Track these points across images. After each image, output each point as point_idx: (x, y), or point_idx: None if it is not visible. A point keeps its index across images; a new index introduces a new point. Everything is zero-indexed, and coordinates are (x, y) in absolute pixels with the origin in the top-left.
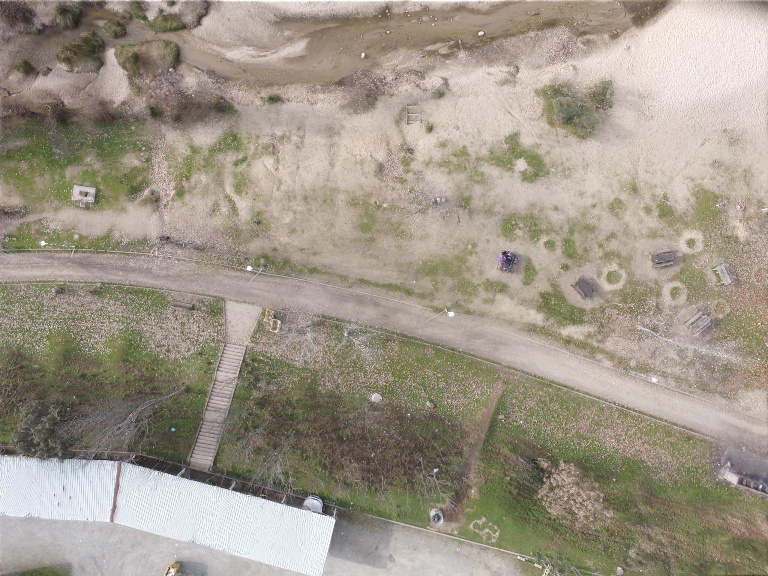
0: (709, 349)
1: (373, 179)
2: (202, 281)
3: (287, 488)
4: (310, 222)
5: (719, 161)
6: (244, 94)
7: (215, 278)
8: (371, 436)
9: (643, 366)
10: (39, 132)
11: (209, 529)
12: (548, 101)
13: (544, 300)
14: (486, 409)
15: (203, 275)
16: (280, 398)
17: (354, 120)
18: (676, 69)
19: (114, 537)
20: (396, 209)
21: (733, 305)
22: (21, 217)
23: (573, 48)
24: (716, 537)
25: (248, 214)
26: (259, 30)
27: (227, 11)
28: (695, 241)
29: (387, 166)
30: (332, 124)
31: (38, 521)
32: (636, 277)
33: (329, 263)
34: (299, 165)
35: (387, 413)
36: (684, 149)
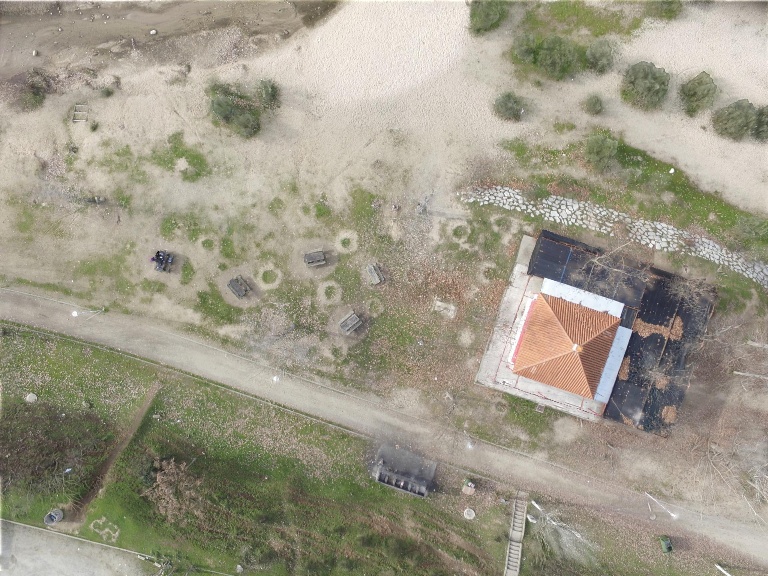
0: (363, 348)
1: (34, 178)
2: None
3: None
4: None
5: (381, 161)
6: None
7: None
8: (13, 436)
9: (299, 365)
10: None
11: None
12: None
13: (201, 299)
14: (139, 408)
15: None
16: None
17: (21, 118)
18: (343, 69)
19: None
20: (55, 208)
21: (387, 304)
22: None
23: (245, 48)
24: (354, 534)
25: None
26: None
27: None
28: (350, 241)
29: (51, 165)
30: None
31: None
32: (292, 276)
33: None
34: None
35: (39, 413)
36: (348, 149)
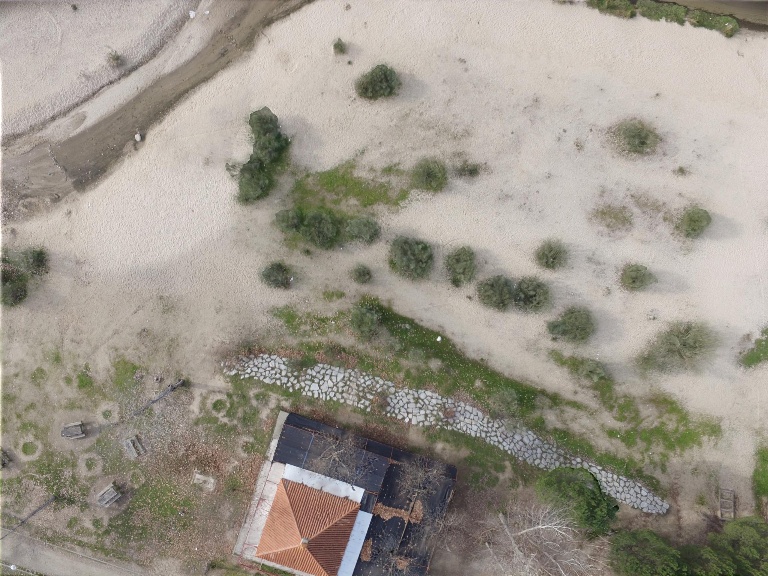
0: (125, 518)
1: None
2: None
3: None
4: None
5: (148, 330)
6: None
7: None
8: None
9: (60, 535)
10: None
11: None
12: None
13: None
14: None
15: None
16: None
17: None
18: (112, 236)
19: None
20: None
21: (148, 475)
22: None
23: (14, 211)
24: None
25: None
26: None
27: None
28: (111, 412)
29: None
30: None
31: None
32: (53, 448)
33: None
34: None
35: None
36: (115, 317)
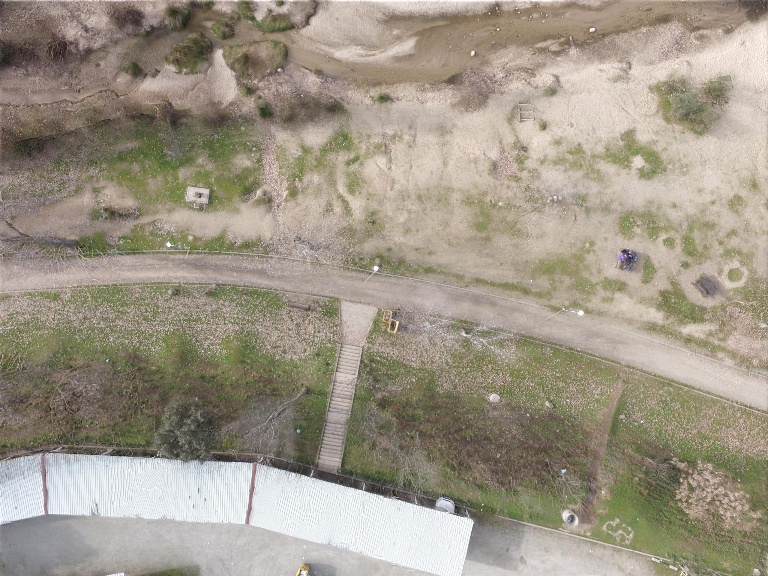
0: None
1: (488, 178)
2: (317, 282)
3: (417, 489)
4: (425, 221)
5: None
6: (353, 93)
7: (330, 278)
8: (494, 437)
9: (766, 365)
10: (149, 134)
11: (362, 531)
12: (662, 97)
13: (664, 298)
14: (607, 409)
15: (318, 276)
16: (399, 399)
17: (466, 118)
18: None
19: (242, 539)
20: (512, 208)
21: None
22: (135, 219)
23: (686, 43)
24: None
25: (362, 214)
26: (368, 29)
27: (335, 10)
28: None
29: (500, 164)
30: (443, 123)
31: (166, 523)
32: (758, 274)
33: (445, 262)
34: (412, 164)
35: (507, 413)
36: None
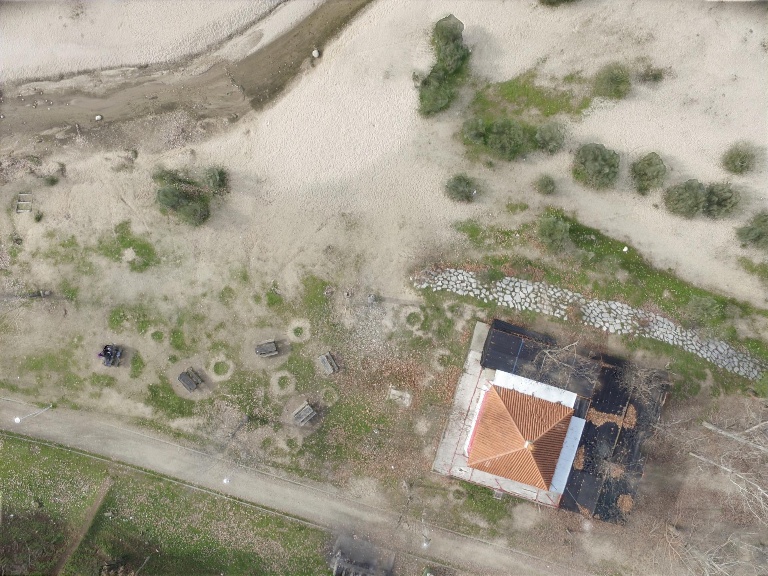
0: (319, 438)
1: None
2: None
3: None
4: None
5: (333, 246)
6: None
7: None
8: None
9: (254, 457)
10: None
11: None
12: None
13: (152, 393)
14: (90, 507)
15: None
16: None
17: None
18: (293, 153)
19: None
20: None
21: (341, 393)
22: None
23: (192, 132)
24: None
25: None
26: None
27: None
28: (302, 329)
29: None
30: None
31: None
32: (244, 367)
33: None
34: None
35: None
36: (300, 234)
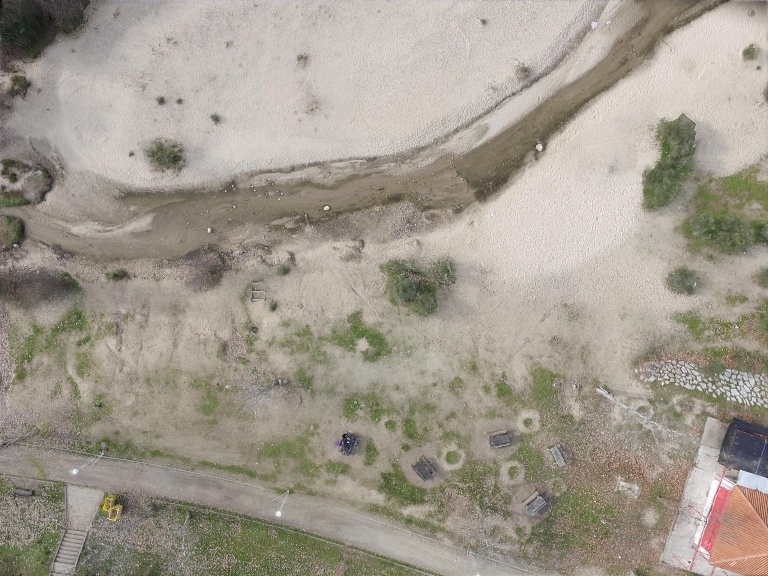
0: (547, 527)
1: (216, 360)
2: (43, 466)
3: None
4: (152, 404)
5: (558, 337)
6: (90, 269)
7: (56, 463)
8: None
9: (483, 544)
10: None
11: None
12: (392, 277)
13: (385, 480)
14: None
15: (44, 460)
16: None
17: (199, 297)
18: (517, 245)
19: None
20: (238, 390)
21: (569, 483)
22: None
23: (418, 223)
24: None
25: (90, 397)
26: (104, 205)
27: (71, 186)
28: (532, 421)
29: (231, 345)
30: (177, 301)
31: None
32: (475, 457)
33: (171, 446)
34: (142, 345)
35: None
36: (524, 325)
